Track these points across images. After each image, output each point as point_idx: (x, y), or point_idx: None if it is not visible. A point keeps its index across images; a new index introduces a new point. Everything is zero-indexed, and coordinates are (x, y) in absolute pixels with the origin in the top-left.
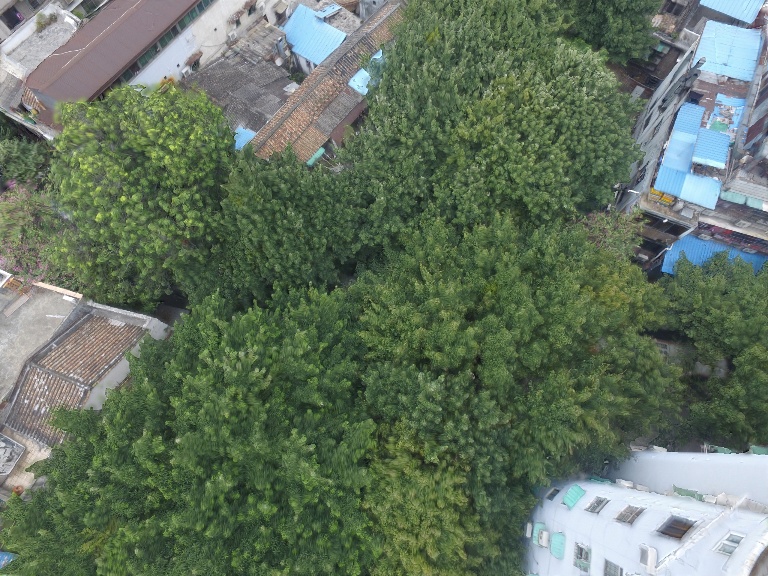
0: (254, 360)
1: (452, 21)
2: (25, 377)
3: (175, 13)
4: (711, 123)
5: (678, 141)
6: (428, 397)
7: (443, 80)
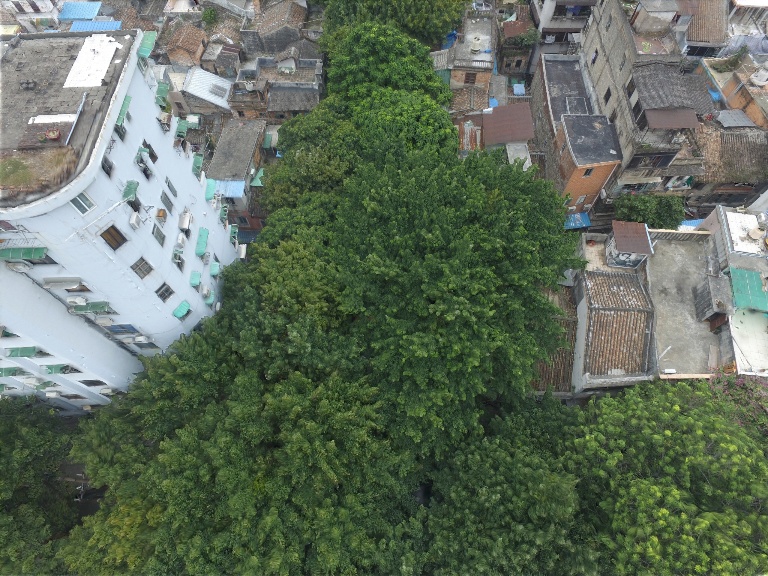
0: None
1: None
2: (648, 302)
3: None
4: None
5: None
6: None
7: None
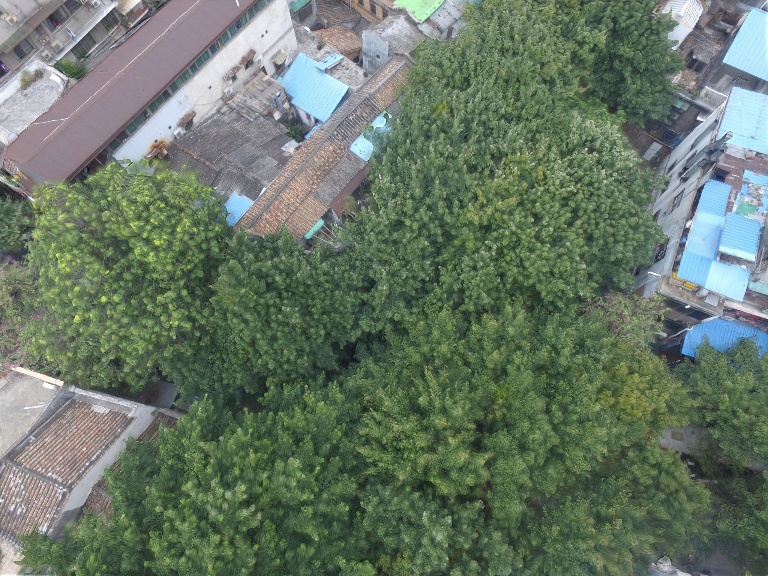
0: (242, 498)
1: (461, 92)
2: (0, 475)
3: (166, 77)
4: (738, 203)
5: (703, 223)
6: (433, 538)
7: (451, 158)
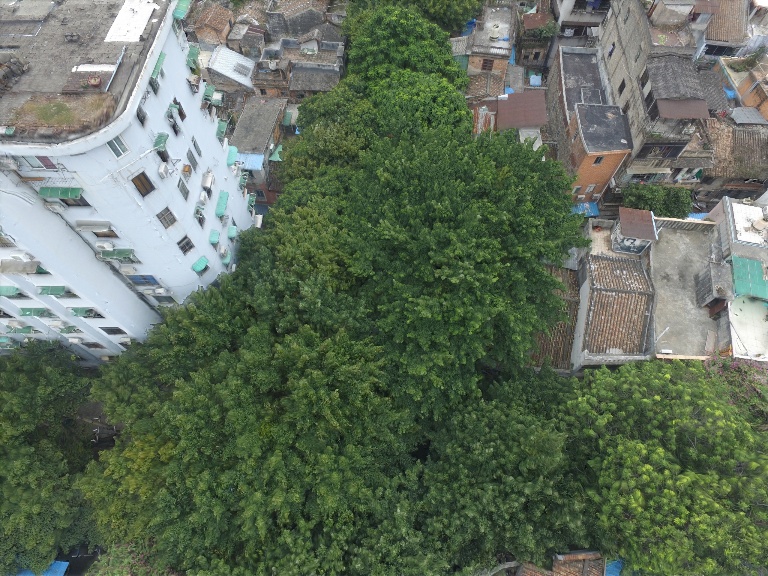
0: None
1: None
2: (649, 286)
3: None
4: None
5: None
6: None
7: None
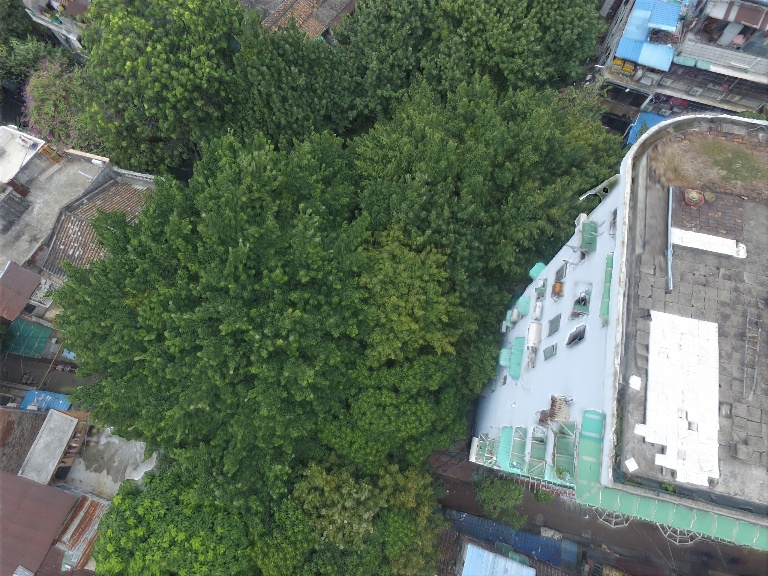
0: (266, 161)
1: None
2: (61, 225)
3: None
4: (666, 1)
5: (637, 17)
6: None
7: None
